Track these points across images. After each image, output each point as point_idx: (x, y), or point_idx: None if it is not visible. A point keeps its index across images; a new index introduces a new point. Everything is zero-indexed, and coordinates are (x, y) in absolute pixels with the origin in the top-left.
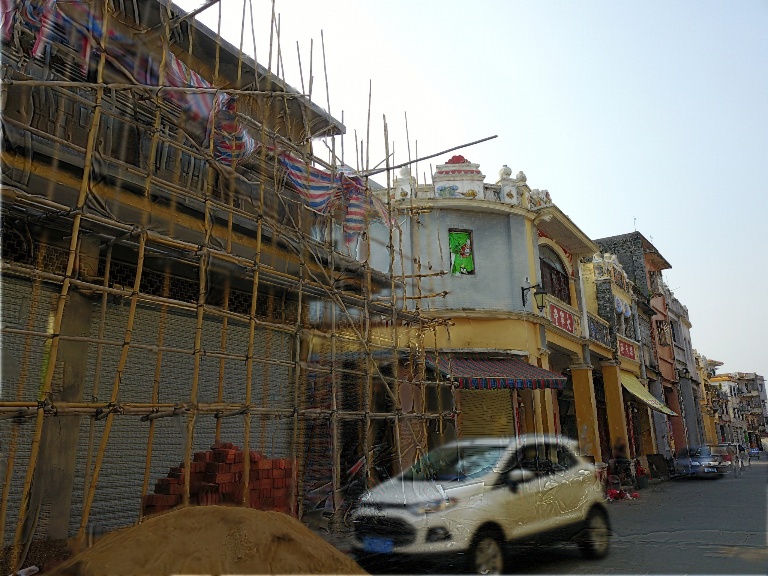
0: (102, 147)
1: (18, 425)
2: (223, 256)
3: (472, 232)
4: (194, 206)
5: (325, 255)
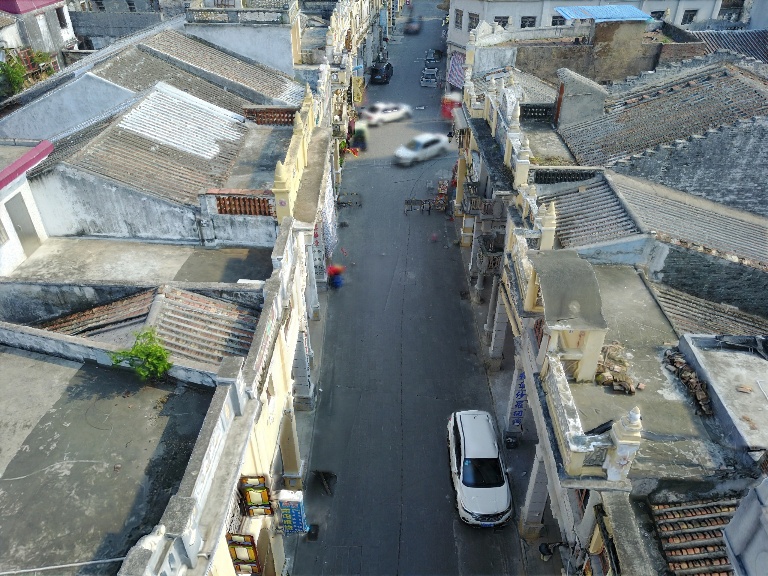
0: None
1: None
2: None
3: None
4: None
5: None
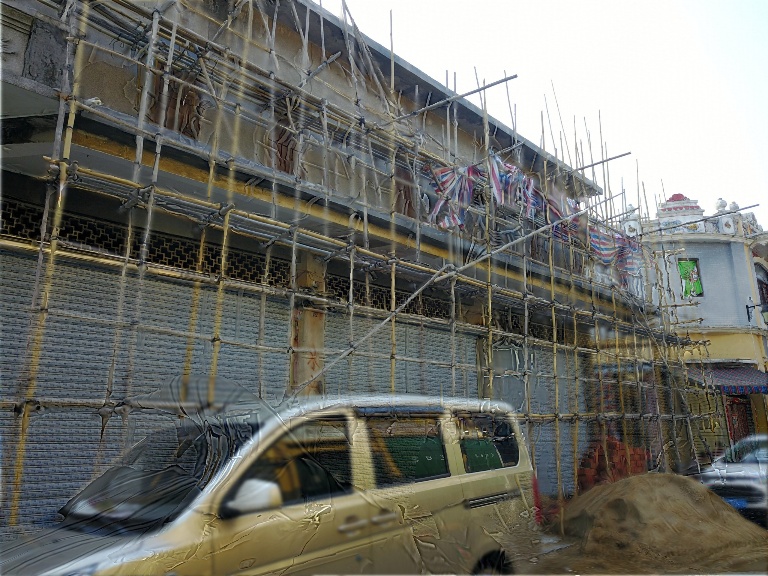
0: (552, 261)
1: (550, 427)
2: (601, 317)
3: (698, 260)
4: (586, 287)
5: (641, 305)
